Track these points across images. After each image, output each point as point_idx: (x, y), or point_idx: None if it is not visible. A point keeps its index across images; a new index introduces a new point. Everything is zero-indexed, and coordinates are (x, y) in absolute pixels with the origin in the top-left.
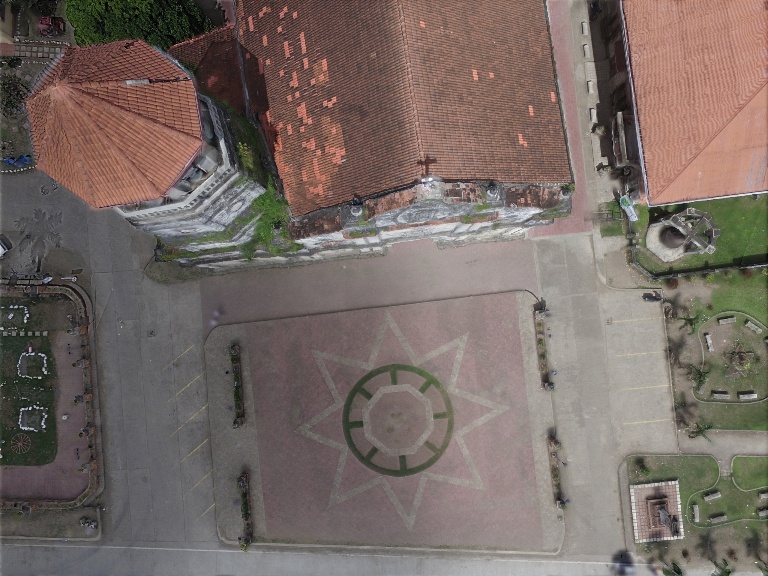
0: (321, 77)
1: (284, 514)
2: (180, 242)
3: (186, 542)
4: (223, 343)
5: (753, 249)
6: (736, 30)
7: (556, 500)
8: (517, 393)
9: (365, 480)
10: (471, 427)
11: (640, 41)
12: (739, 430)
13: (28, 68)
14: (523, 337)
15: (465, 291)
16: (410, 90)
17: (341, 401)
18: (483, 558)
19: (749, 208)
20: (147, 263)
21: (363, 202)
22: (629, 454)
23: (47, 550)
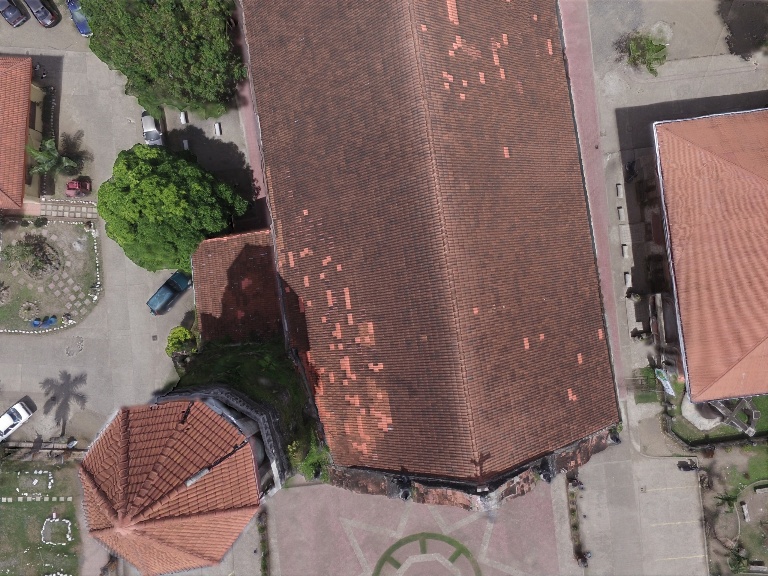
0: (367, 339)
1: None
2: None
3: None
4: None
5: None
6: None
7: None
8: (549, 563)
9: None
10: None
11: (682, 234)
12: None
13: (54, 227)
14: (555, 506)
15: None
16: (464, 387)
17: (369, 570)
18: None
19: None
20: None
21: (411, 481)
22: None
23: None
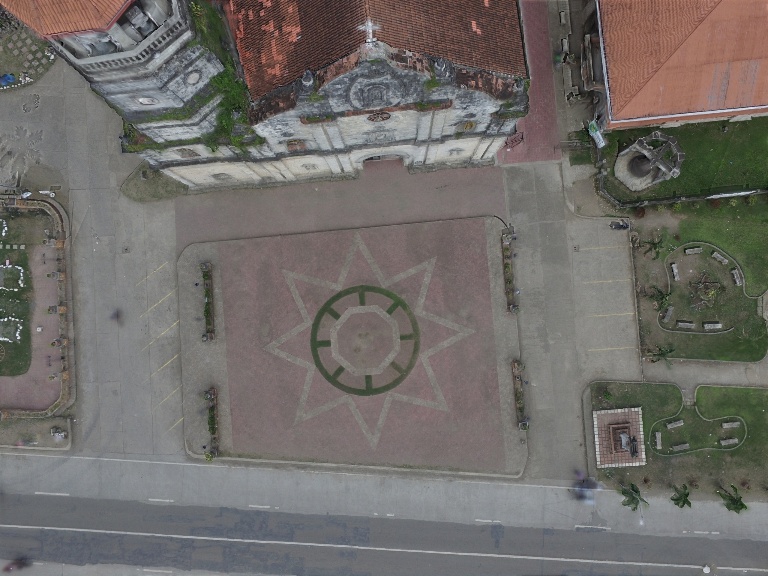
0: None
1: (251, 430)
2: (141, 119)
3: (154, 455)
4: (196, 260)
5: (721, 181)
6: None
7: (519, 422)
8: (483, 317)
9: (331, 398)
10: (437, 349)
11: None
12: (703, 360)
13: None
14: (491, 262)
15: (435, 216)
16: None
17: (310, 320)
18: (446, 479)
19: (718, 140)
20: (124, 181)
21: (315, 74)
22: (593, 380)
23: (18, 459)
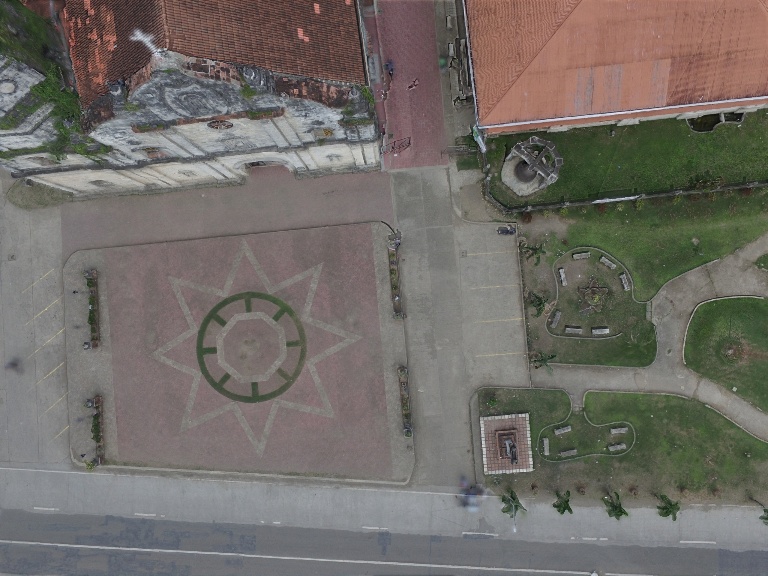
0: None
1: (136, 437)
2: None
3: (39, 463)
4: (81, 268)
5: (609, 185)
6: None
7: None
8: (370, 323)
9: (217, 406)
10: (323, 356)
11: None
12: (592, 365)
13: None
14: (377, 268)
15: (322, 221)
16: None
17: (196, 327)
18: (333, 486)
19: (606, 145)
20: (10, 188)
21: None
22: (481, 386)
23: None
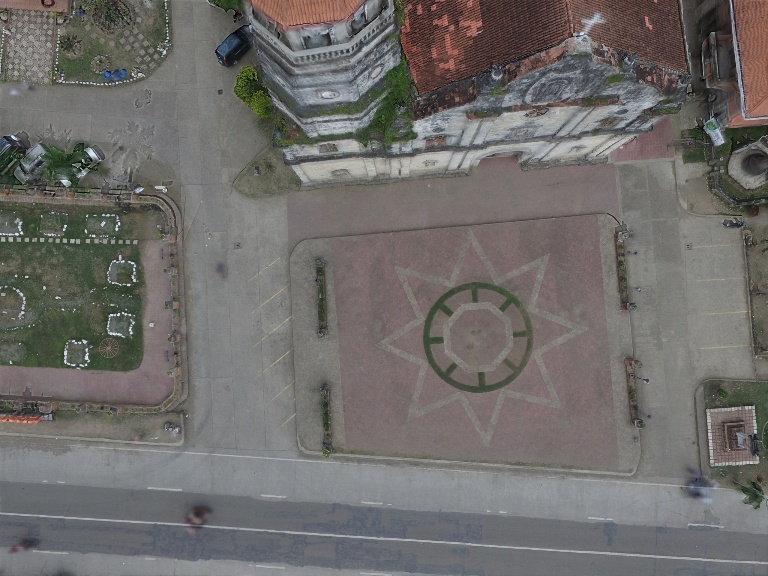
0: None
1: (363, 426)
2: (313, 113)
3: (266, 451)
4: (308, 257)
5: None
6: None
7: (634, 419)
8: (596, 314)
9: (444, 395)
10: (550, 346)
11: None
12: None
13: None
14: (604, 259)
15: (547, 213)
16: None
17: (422, 317)
18: (558, 476)
19: None
20: (236, 177)
21: (502, 68)
22: (706, 378)
23: (130, 454)
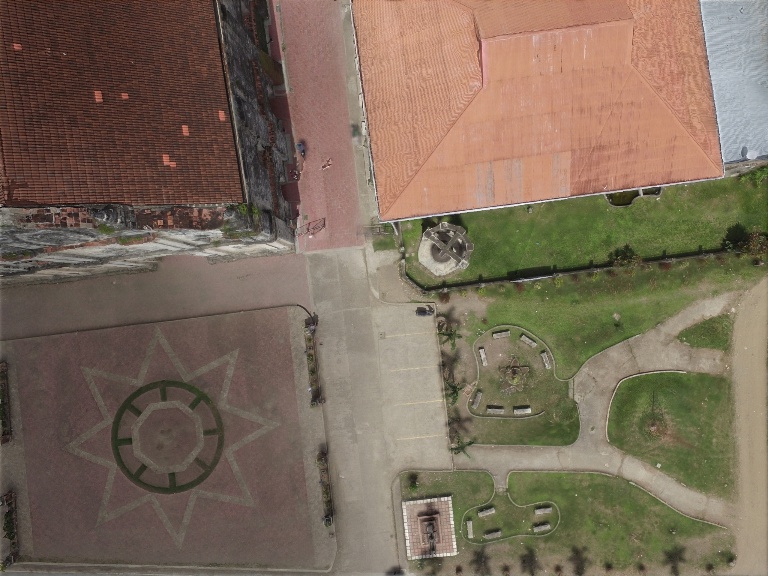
0: None
1: (51, 533)
2: None
3: None
4: None
5: (528, 262)
6: (447, 45)
7: None
8: (288, 409)
9: (134, 498)
10: (241, 444)
11: (369, 56)
12: (514, 445)
13: None
14: (294, 352)
15: (237, 306)
16: None
17: (110, 418)
18: None
19: (523, 221)
20: None
21: None
22: (402, 470)
23: None
